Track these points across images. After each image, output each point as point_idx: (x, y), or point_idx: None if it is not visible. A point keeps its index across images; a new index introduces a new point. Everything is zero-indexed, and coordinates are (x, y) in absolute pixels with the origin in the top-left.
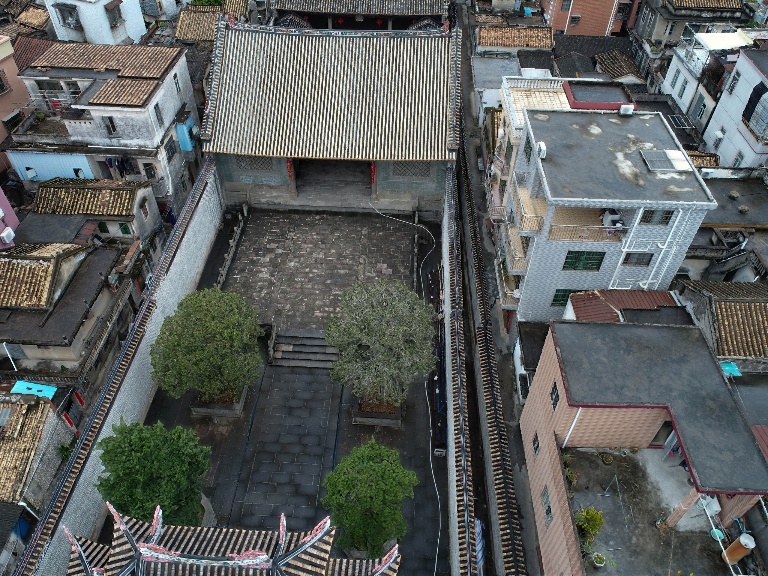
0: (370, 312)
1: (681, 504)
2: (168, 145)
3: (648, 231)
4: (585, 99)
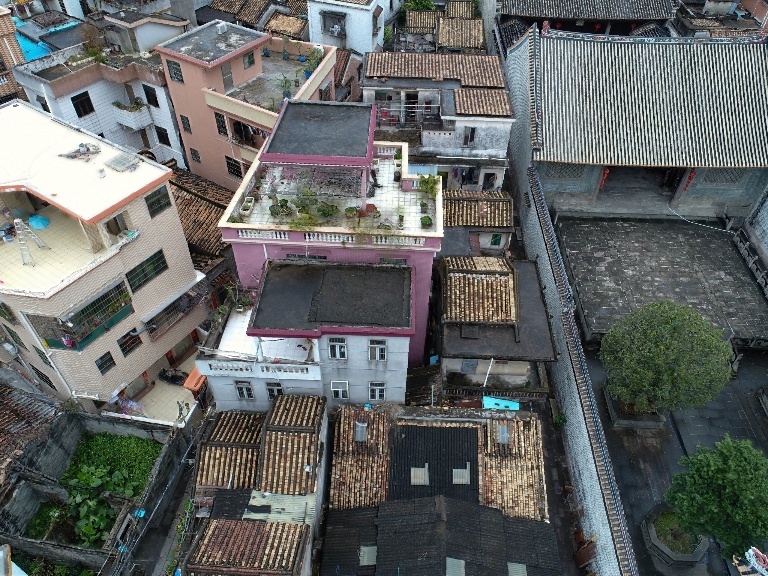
0: None
1: None
2: None
3: None
4: None
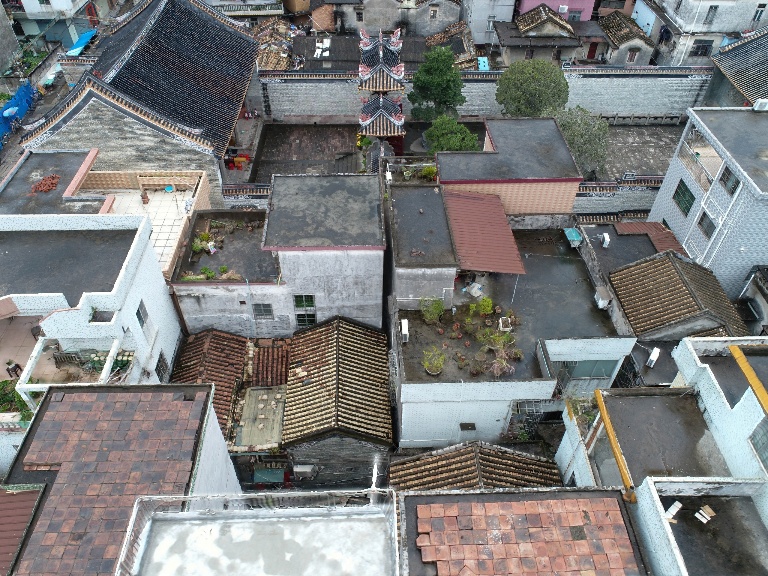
0: None
1: None
2: (703, 44)
3: (721, 194)
4: None
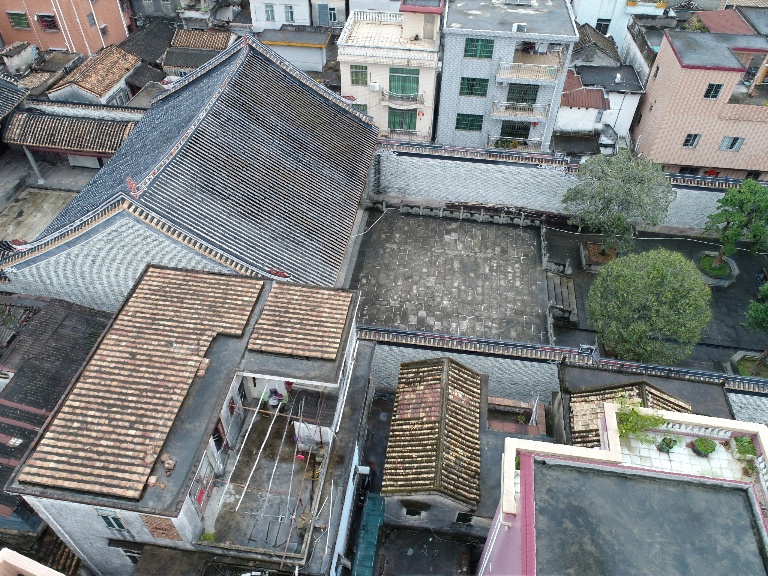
0: (635, 170)
1: (759, 74)
2: None
3: None
4: (430, 6)
